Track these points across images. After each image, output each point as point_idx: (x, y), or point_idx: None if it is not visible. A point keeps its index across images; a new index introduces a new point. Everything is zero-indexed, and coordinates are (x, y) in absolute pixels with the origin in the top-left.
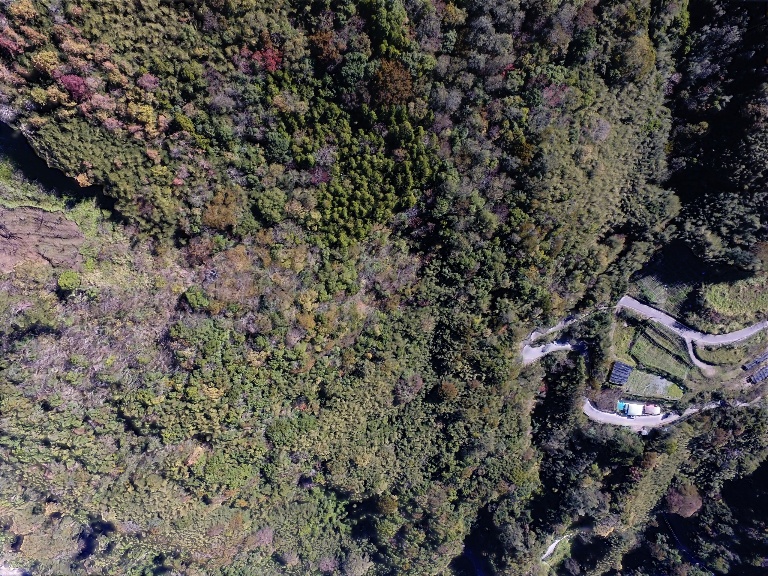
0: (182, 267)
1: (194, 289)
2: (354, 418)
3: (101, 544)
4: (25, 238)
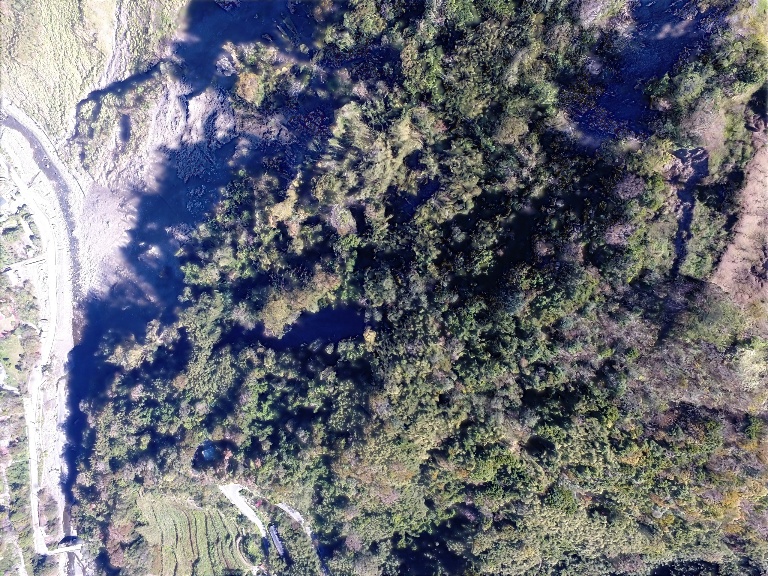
0: (766, 400)
1: (759, 423)
2: (580, 535)
3: (329, 377)
4: (765, 289)
